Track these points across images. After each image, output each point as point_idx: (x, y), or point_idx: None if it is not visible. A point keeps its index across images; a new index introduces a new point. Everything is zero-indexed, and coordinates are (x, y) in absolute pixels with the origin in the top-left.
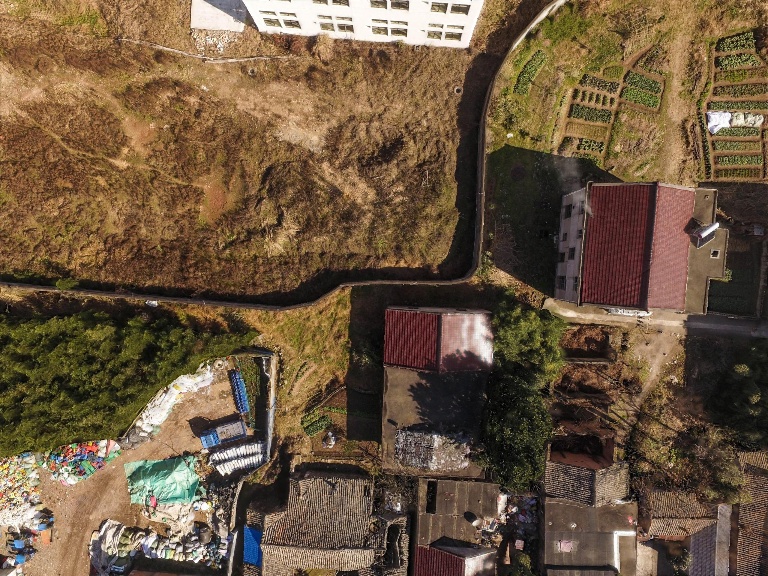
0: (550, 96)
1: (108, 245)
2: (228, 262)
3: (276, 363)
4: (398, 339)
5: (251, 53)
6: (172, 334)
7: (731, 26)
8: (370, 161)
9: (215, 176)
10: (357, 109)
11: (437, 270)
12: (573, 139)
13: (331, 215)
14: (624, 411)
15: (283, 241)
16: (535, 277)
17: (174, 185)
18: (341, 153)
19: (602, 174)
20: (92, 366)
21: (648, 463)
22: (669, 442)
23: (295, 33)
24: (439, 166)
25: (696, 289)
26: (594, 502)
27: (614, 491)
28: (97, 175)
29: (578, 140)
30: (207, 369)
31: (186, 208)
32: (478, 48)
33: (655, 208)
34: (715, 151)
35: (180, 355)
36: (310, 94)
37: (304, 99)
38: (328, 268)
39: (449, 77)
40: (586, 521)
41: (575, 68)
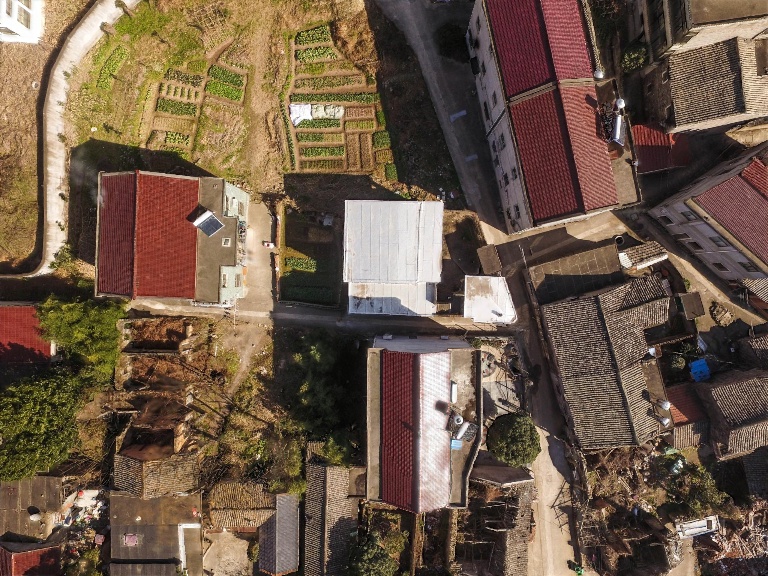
0: (131, 90)
1: None
2: None
3: None
4: None
5: None
6: None
7: (306, 20)
8: None
9: None
10: None
11: (16, 263)
12: (157, 132)
13: None
14: (216, 403)
15: None
16: None
17: None
18: None
19: (190, 167)
20: None
21: (235, 455)
22: (256, 433)
23: None
24: (15, 160)
25: (210, 277)
26: (142, 494)
27: (175, 483)
28: None
29: (165, 133)
30: None
31: None
32: (50, 43)
33: (136, 196)
34: (299, 143)
35: None
36: None
37: None
38: None
39: (26, 72)
40: (151, 514)
41: (157, 62)
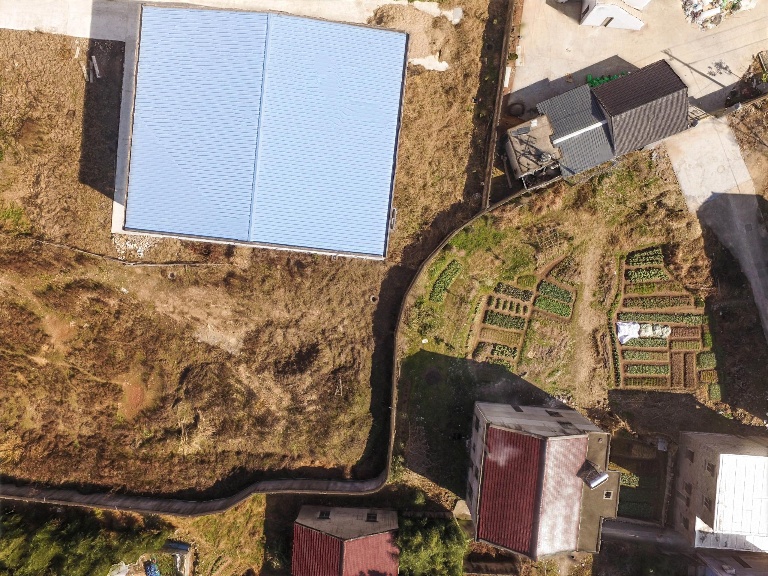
0: (464, 304)
1: (24, 443)
2: (144, 462)
3: (192, 555)
4: (305, 555)
5: (171, 258)
6: (80, 548)
7: (640, 242)
8: (285, 368)
9: (134, 374)
10: (275, 314)
11: (350, 474)
12: (487, 346)
13: (247, 418)
14: None
15: (200, 439)
16: (448, 478)
17: (92, 383)
18: (258, 357)
19: (515, 379)
20: (0, 575)
21: None
22: None
23: (214, 242)
24: (353, 374)
25: (590, 528)
26: None
27: None
28: (16, 372)
29: (492, 345)
30: (122, 562)
31: (104, 405)
32: (393, 260)
33: (545, 463)
34: (624, 360)
35: (87, 569)
36: (229, 298)
37: (223, 303)
38: (244, 467)
39: (365, 286)
40: None
41: (489, 277)
